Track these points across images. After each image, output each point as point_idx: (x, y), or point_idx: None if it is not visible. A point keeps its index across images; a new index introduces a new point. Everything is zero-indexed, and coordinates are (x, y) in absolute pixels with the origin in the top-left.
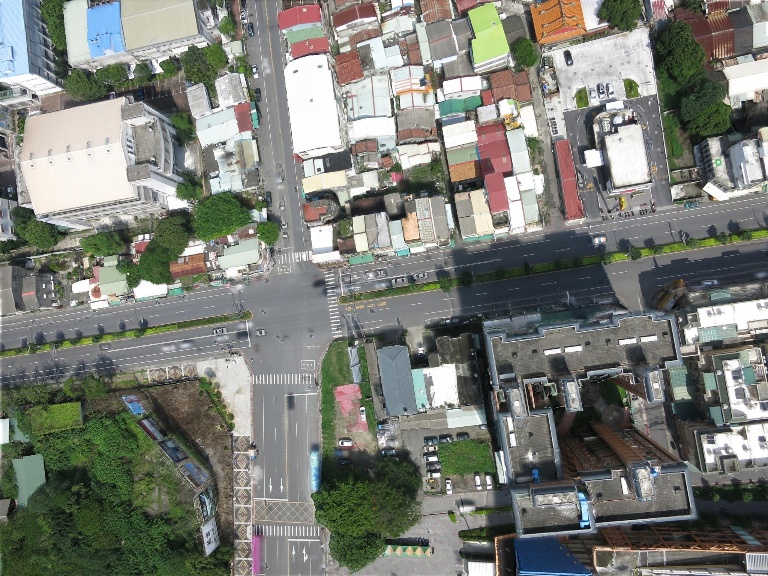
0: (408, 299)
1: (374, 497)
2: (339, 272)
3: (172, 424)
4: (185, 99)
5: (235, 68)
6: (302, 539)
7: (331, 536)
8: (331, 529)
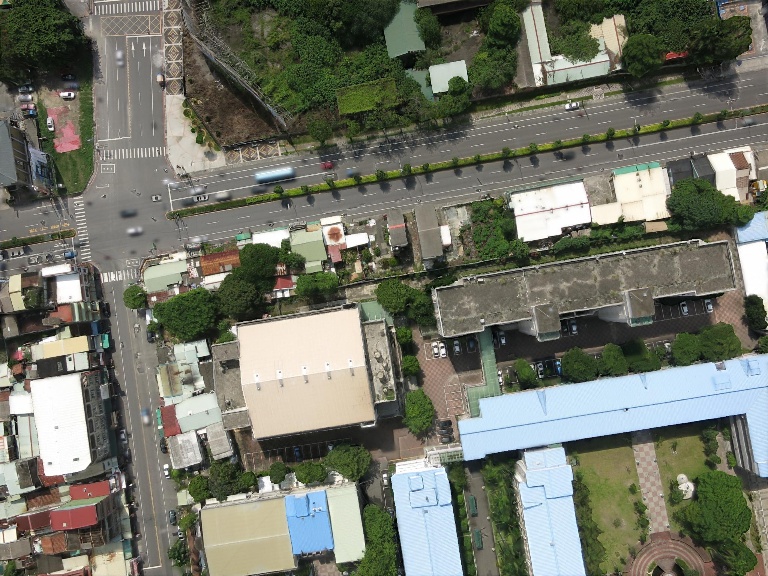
0: (8, 236)
1: (6, 42)
2: (76, 261)
3: (251, 102)
4: (247, 446)
5: (187, 476)
6: (111, 2)
7: (56, 3)
8: (50, 8)
